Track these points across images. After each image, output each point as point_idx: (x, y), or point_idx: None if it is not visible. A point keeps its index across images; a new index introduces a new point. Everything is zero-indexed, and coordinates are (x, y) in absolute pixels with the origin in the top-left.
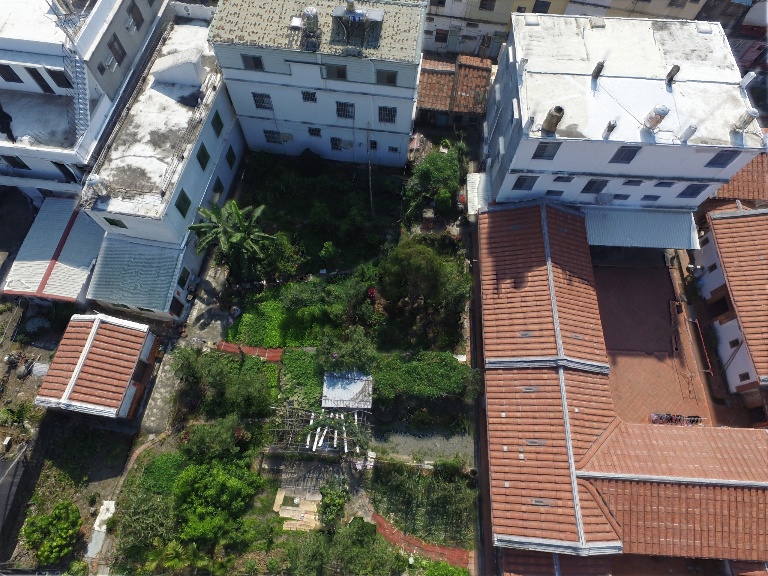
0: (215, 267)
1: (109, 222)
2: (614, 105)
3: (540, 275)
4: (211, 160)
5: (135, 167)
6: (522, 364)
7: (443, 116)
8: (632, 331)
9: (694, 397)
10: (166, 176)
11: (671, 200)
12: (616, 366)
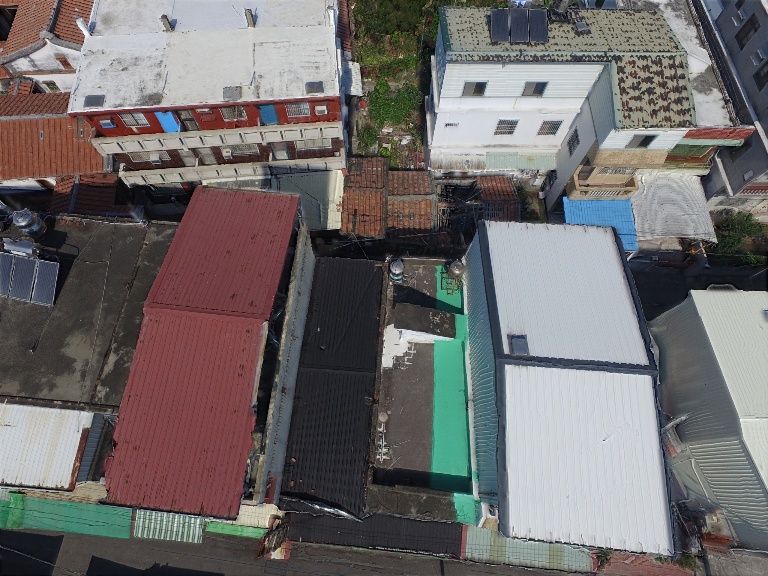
0: None
1: None
2: (238, 3)
3: None
4: None
5: None
6: None
7: None
8: None
9: None
10: None
11: None
12: None
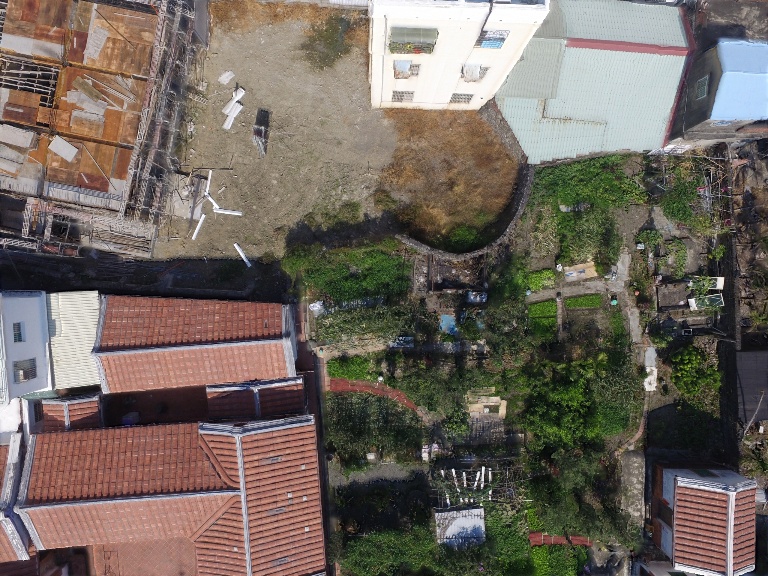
0: None
1: None
2: None
3: None
4: None
5: None
6: None
7: None
8: None
9: (106, 553)
10: None
11: None
12: (183, 574)
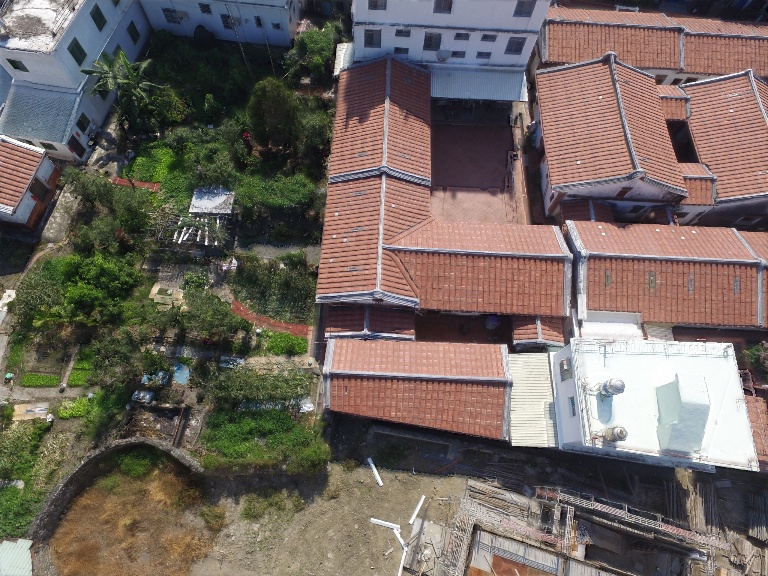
0: (116, 122)
1: (12, 65)
2: None
3: (379, 111)
4: (109, 25)
5: (33, 16)
6: (355, 175)
7: (326, 3)
8: (472, 173)
9: (516, 221)
10: (56, 20)
11: (502, 58)
12: (454, 198)
